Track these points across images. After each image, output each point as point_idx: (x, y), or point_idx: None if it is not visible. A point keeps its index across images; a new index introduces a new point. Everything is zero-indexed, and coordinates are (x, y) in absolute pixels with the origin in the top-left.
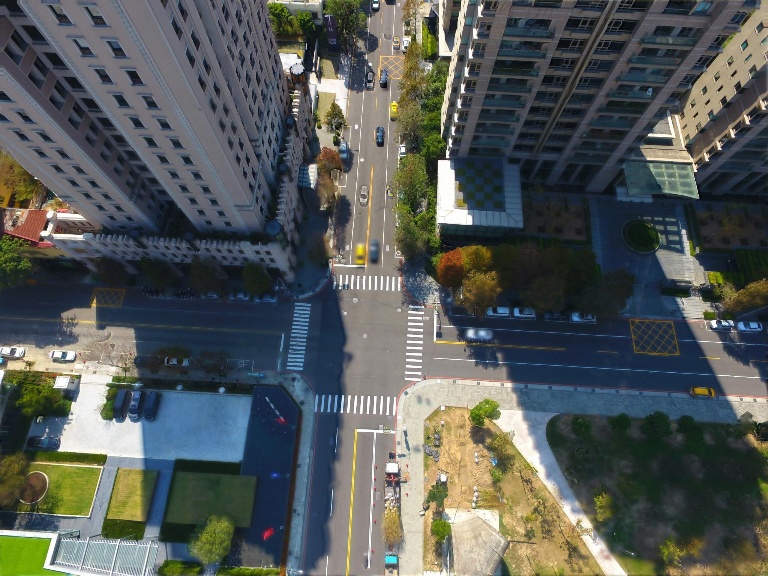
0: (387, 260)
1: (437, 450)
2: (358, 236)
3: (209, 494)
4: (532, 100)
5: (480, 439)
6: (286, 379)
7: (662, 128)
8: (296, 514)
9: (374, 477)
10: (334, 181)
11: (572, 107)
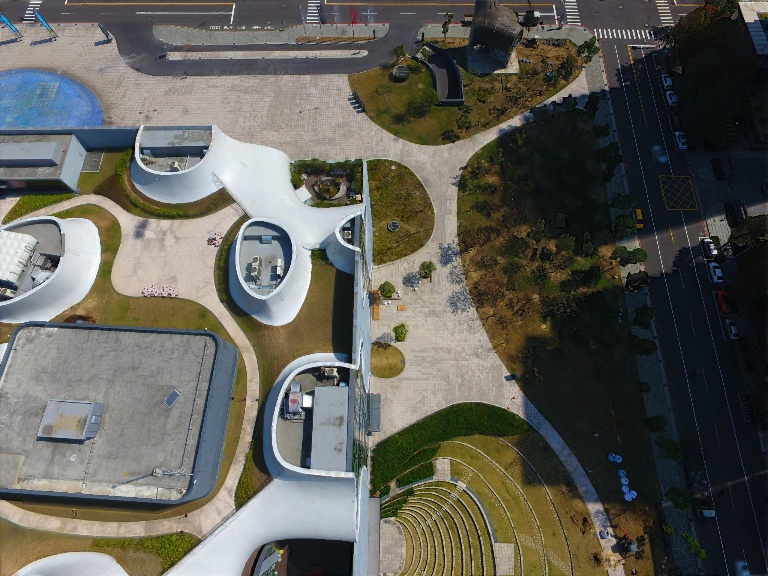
0: None
1: None
2: None
3: None
4: None
5: None
6: None
7: None
8: None
9: None
10: None
11: None
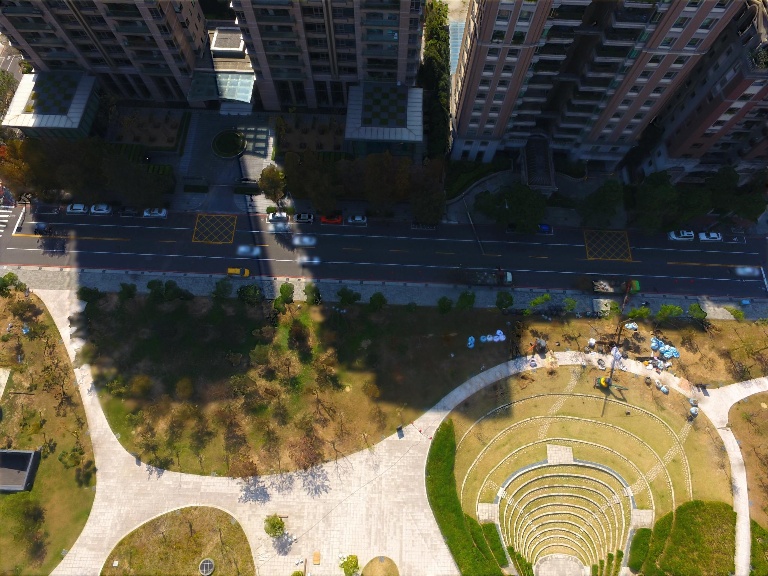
0: None
1: None
2: None
3: None
4: (44, 6)
5: None
6: None
7: (233, 43)
8: None
9: None
10: None
11: (91, 14)
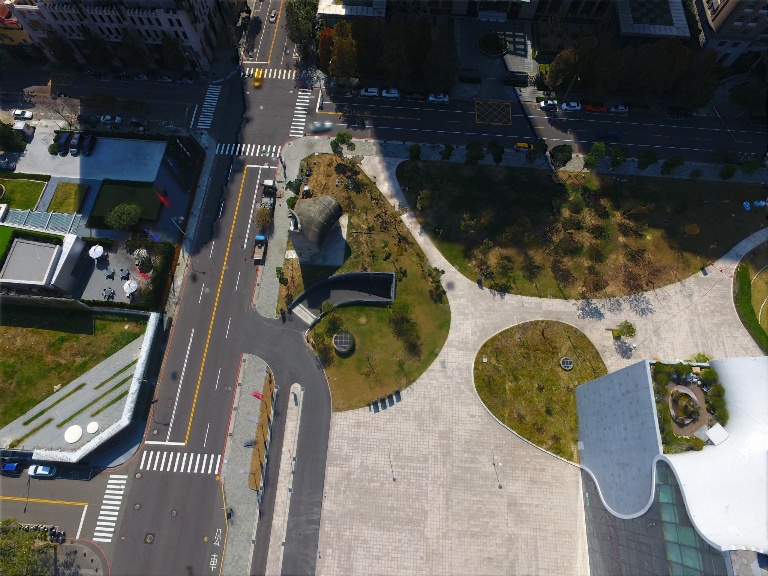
0: (286, 59)
1: (307, 178)
2: (265, 43)
3: (127, 199)
4: None
5: (342, 171)
6: (196, 133)
7: None
8: (193, 215)
9: (256, 194)
10: (250, 7)
11: None
